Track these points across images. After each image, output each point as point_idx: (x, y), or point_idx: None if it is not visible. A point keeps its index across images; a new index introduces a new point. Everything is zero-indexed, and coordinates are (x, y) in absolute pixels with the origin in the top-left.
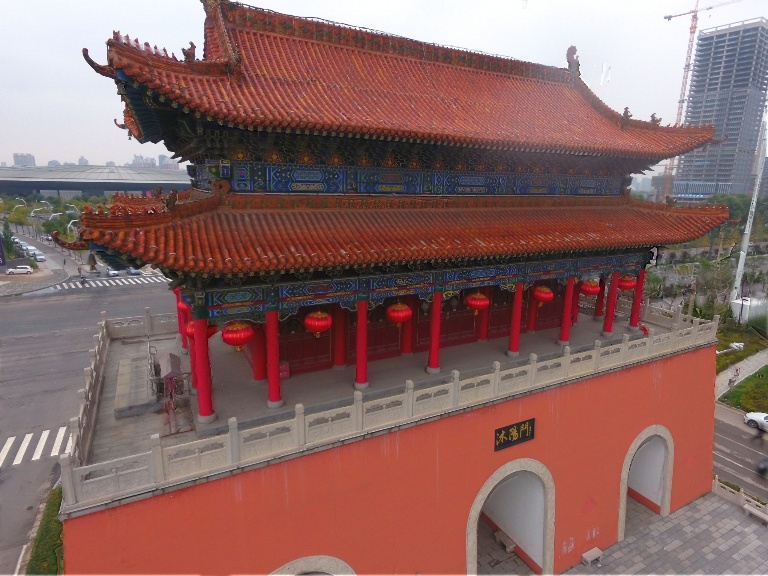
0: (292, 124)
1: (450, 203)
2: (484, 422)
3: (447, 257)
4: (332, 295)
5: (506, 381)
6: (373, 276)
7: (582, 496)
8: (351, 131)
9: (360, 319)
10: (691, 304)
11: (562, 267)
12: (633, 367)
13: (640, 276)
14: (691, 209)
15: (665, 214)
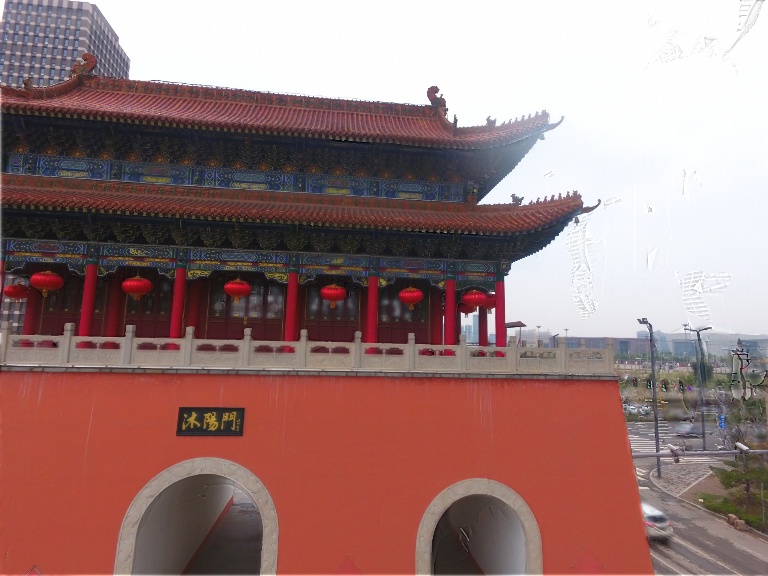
0: (13, 105)
1: (217, 194)
2: (163, 393)
3: (136, 210)
4: (61, 256)
5: (204, 352)
6: (103, 243)
7: (335, 554)
8: (67, 112)
9: (86, 282)
10: (767, 406)
11: (355, 263)
12: (428, 379)
13: (497, 291)
14: (540, 203)
15: (512, 214)
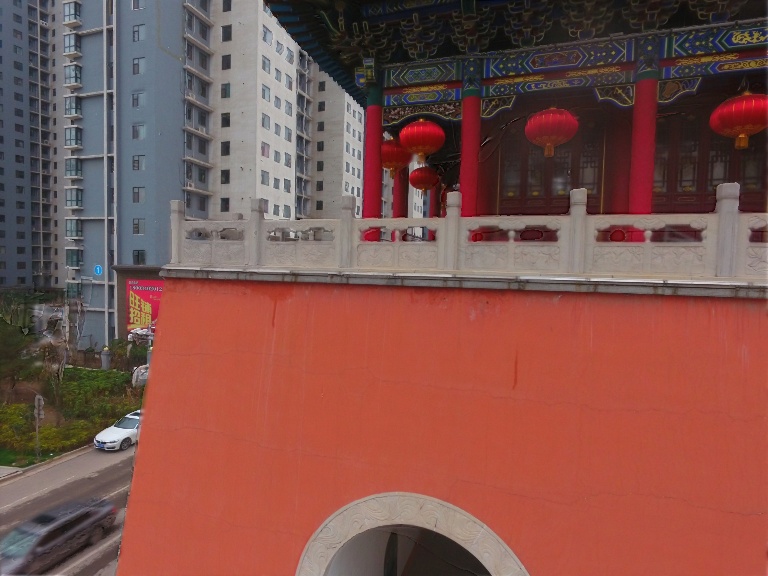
0: None
1: None
2: None
3: None
4: None
5: None
6: None
7: None
8: None
9: None
10: None
11: None
12: None
13: None
14: None
15: None
